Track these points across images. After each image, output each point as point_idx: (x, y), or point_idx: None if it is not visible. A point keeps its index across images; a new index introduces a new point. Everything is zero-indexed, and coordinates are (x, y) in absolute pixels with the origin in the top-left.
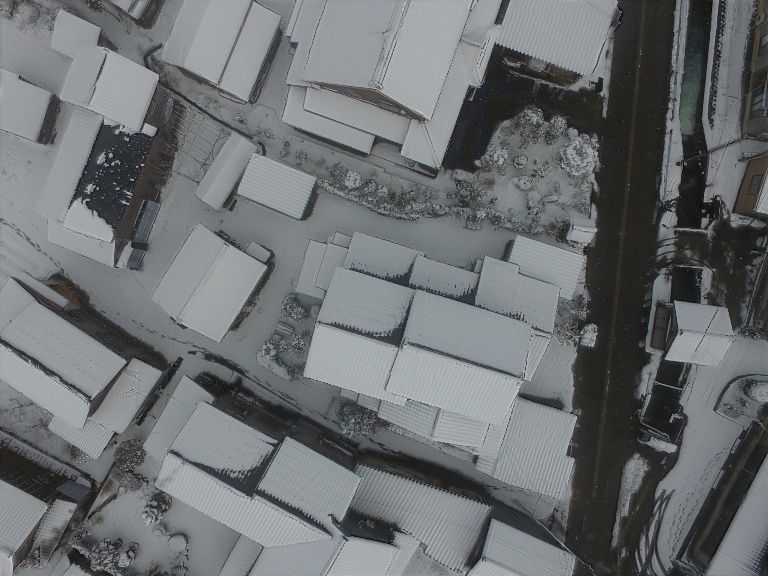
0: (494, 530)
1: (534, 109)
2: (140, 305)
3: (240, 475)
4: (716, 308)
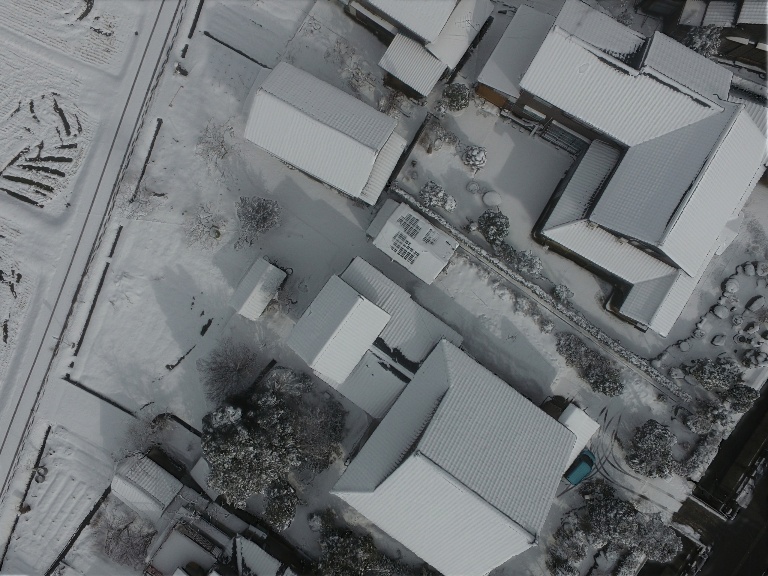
0: None
1: None
2: None
3: (621, 56)
4: None
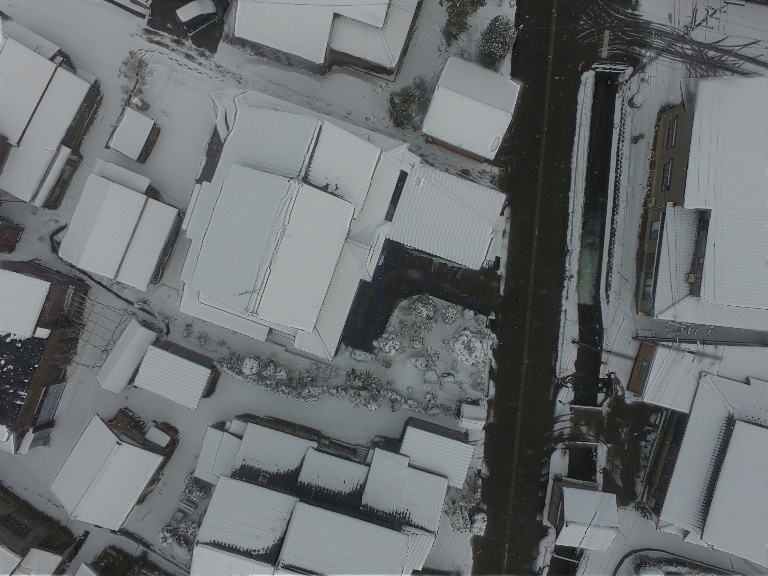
0: None
1: (424, 302)
2: (47, 480)
3: None
4: (604, 495)
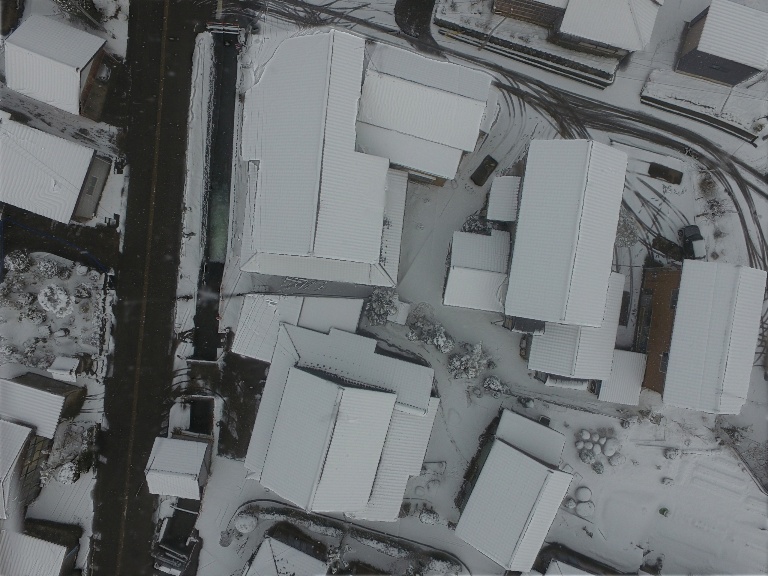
0: None
1: (14, 255)
2: None
3: None
4: (194, 444)
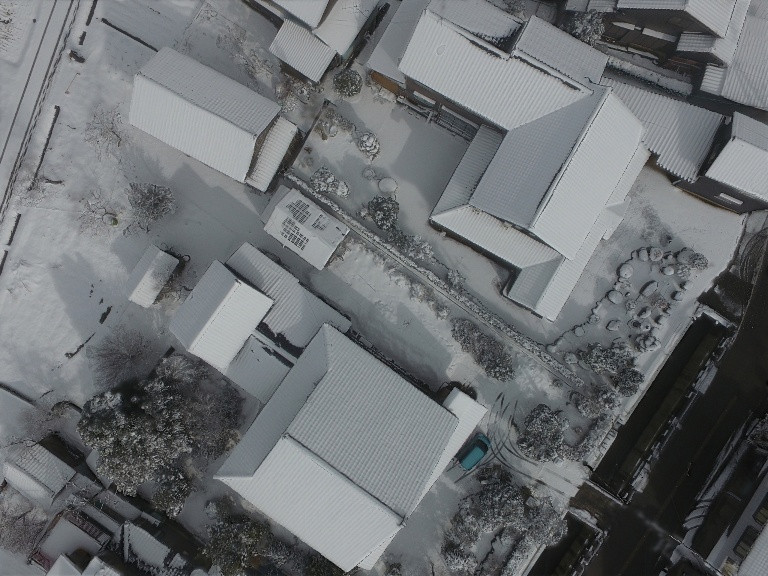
0: (739, 119)
1: None
2: None
3: (494, 40)
4: None
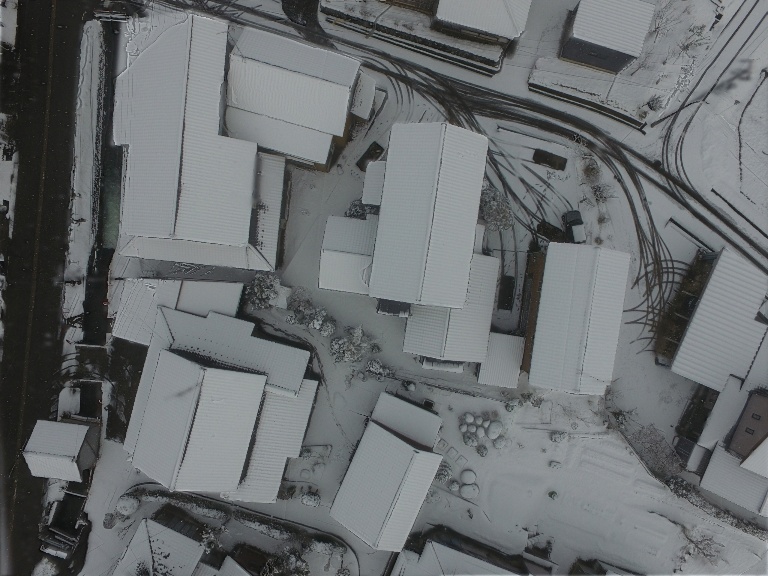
0: None
1: None
2: None
3: None
4: (76, 427)
